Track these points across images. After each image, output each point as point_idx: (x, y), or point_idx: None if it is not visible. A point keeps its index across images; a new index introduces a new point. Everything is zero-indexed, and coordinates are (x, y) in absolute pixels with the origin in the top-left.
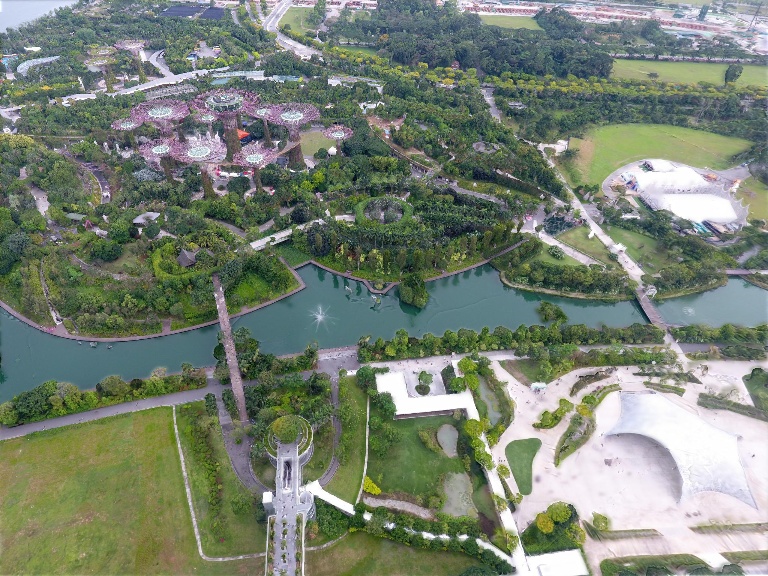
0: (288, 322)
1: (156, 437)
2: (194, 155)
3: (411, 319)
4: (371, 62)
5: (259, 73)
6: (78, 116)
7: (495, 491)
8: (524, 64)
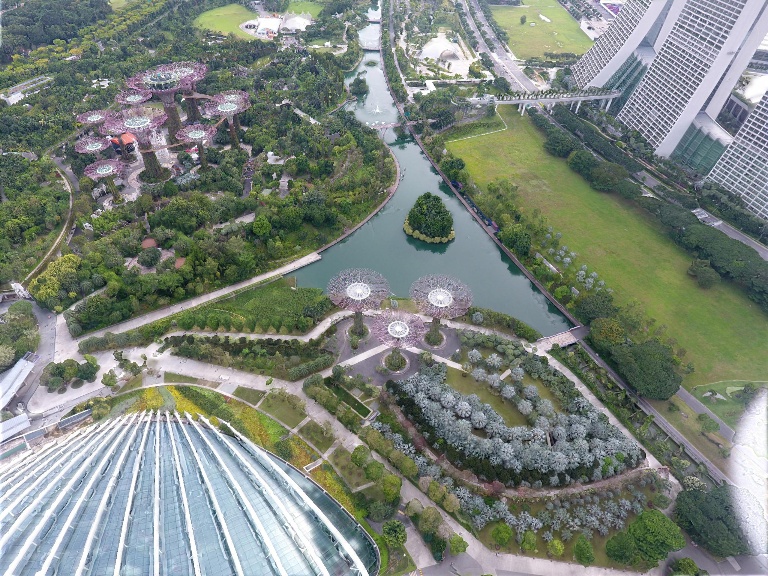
0: (379, 122)
1: (460, 144)
2: (234, 107)
3: (362, 107)
4: None
5: None
6: (7, 233)
7: (466, 80)
8: (71, 22)
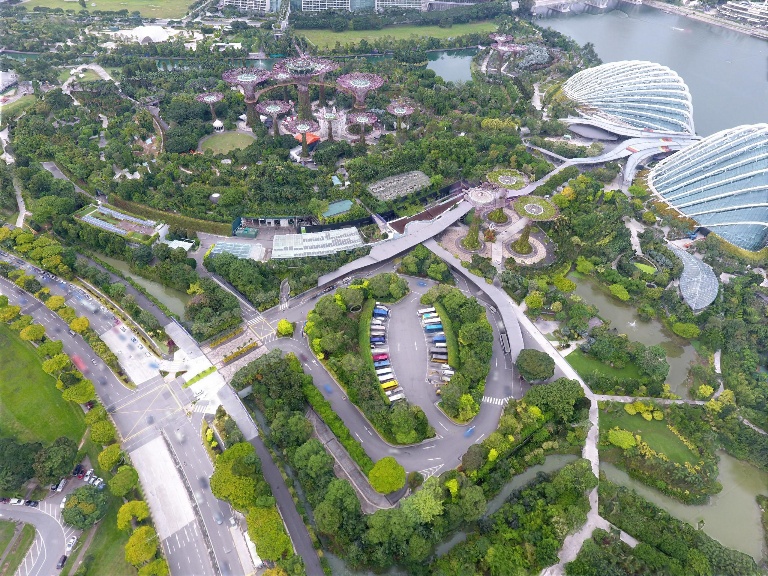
0: None
1: None
2: None
3: None
4: (39, 286)
5: (280, 239)
6: None
7: None
8: None
